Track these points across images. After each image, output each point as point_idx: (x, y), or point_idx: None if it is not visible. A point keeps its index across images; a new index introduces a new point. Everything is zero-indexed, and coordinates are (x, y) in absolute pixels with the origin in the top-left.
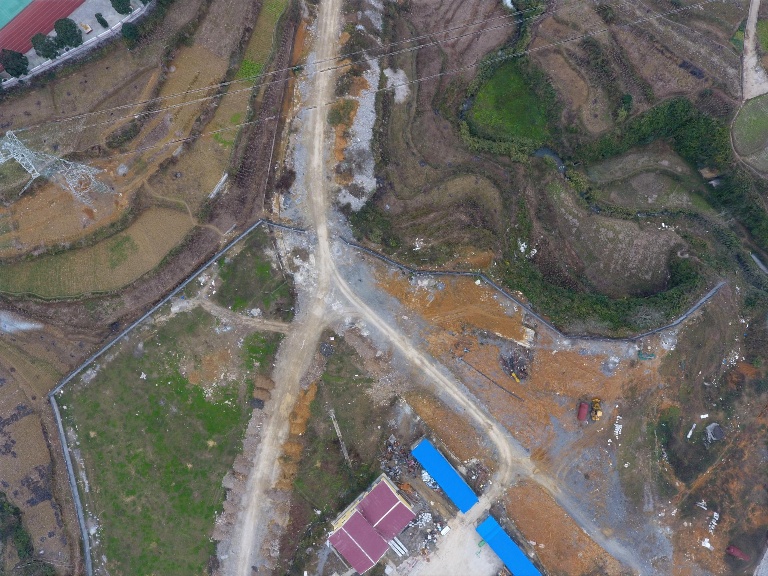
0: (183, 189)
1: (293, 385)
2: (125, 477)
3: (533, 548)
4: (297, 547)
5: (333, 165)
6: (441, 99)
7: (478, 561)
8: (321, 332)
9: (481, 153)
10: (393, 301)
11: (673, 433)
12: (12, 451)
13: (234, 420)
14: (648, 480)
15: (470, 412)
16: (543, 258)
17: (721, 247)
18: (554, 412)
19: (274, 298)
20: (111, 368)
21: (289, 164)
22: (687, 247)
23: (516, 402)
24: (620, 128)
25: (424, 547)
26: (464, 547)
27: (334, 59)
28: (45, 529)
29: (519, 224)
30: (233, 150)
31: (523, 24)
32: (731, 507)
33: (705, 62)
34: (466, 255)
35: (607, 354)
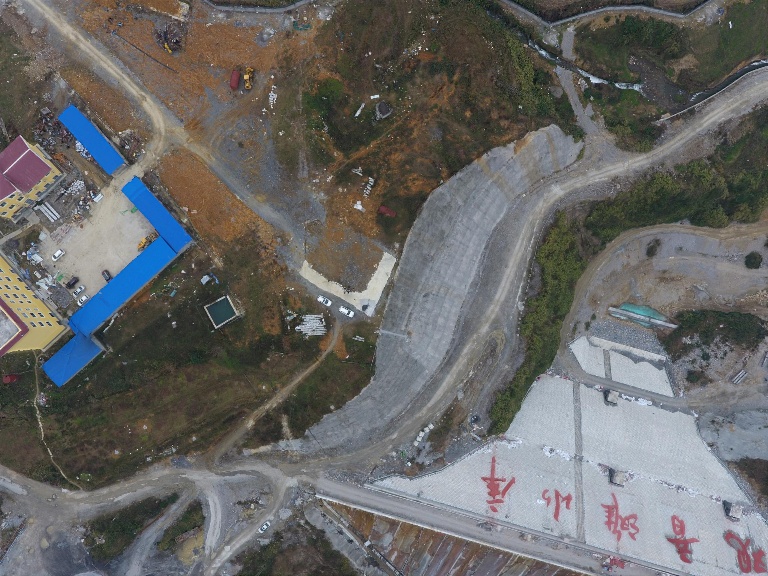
0: None
1: None
2: None
3: (186, 214)
4: None
5: None
6: None
7: (131, 227)
8: None
9: None
10: None
11: (333, 106)
12: None
13: None
14: (303, 148)
15: (124, 85)
16: None
17: None
18: (209, 84)
19: None
20: None
21: None
22: None
23: (170, 74)
24: None
25: (77, 213)
26: (117, 214)
27: None
28: None
29: None
30: None
31: None
32: (388, 173)
33: None
34: None
35: (263, 26)
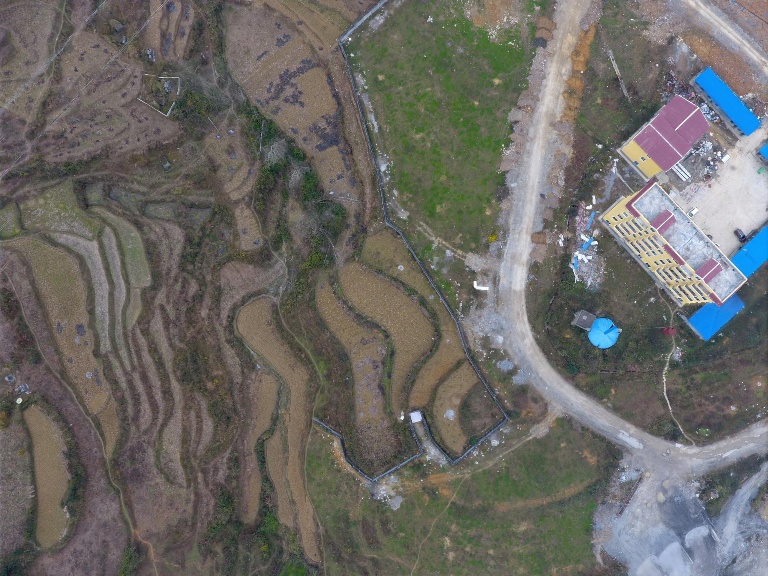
0: None
1: (574, 26)
2: (414, 115)
3: None
4: (581, 178)
5: None
6: None
7: (758, 187)
8: None
9: None
10: None
11: None
12: (299, 101)
13: (518, 59)
14: None
15: (745, 50)
16: None
17: None
18: None
19: None
20: (399, 13)
21: None
22: None
23: None
24: None
25: (706, 173)
26: (744, 174)
27: None
28: (334, 172)
29: None
30: None
31: None
32: None
33: None
34: None
35: None
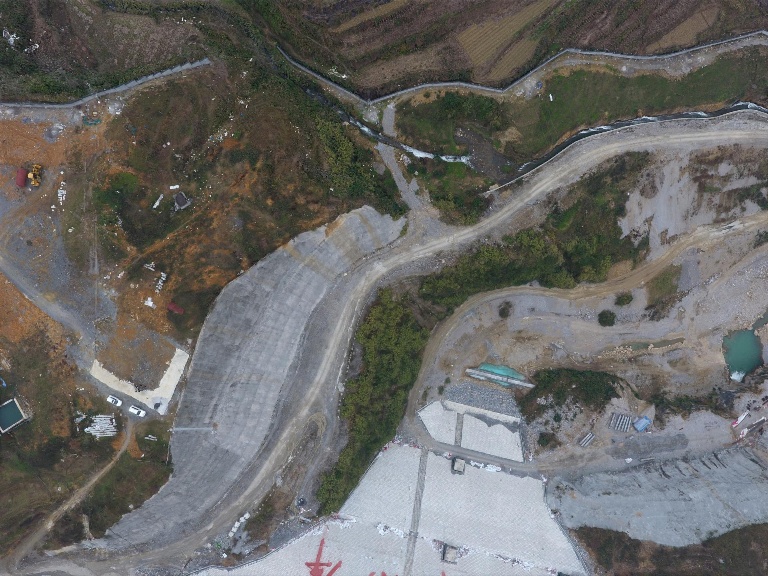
0: None
1: None
2: None
3: None
4: None
5: None
6: None
7: None
8: None
9: None
10: None
11: (127, 199)
12: None
13: None
14: (93, 244)
15: None
16: None
17: (246, 40)
18: None
19: None
20: None
21: None
22: None
23: None
24: None
25: None
26: None
27: None
28: None
29: (2, 13)
30: None
31: None
32: (181, 267)
33: None
34: None
35: (51, 121)
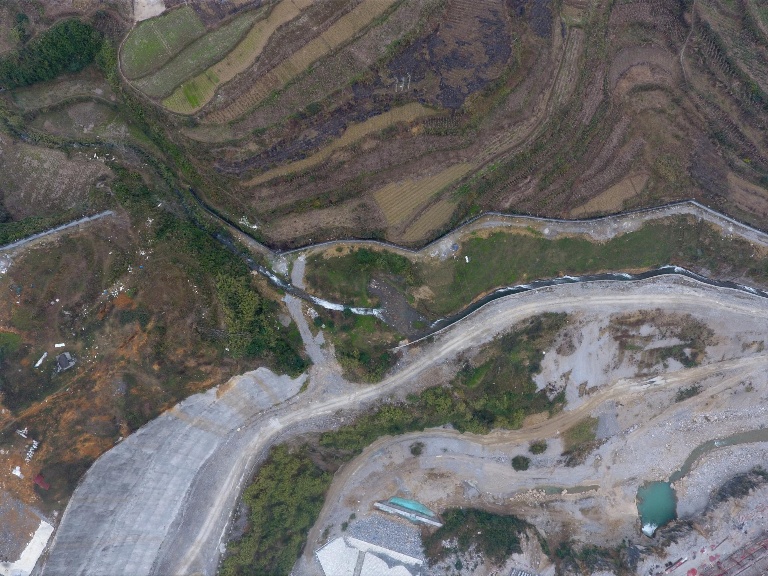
0: None
1: None
2: None
3: None
4: None
5: None
6: None
7: None
8: None
9: None
10: None
11: (6, 359)
12: None
13: None
14: None
15: None
16: None
17: (159, 181)
18: None
19: None
20: None
21: None
22: (112, 178)
23: None
24: (18, 49)
25: None
26: None
27: None
28: None
29: None
30: None
31: None
32: (54, 436)
33: None
34: None
35: None
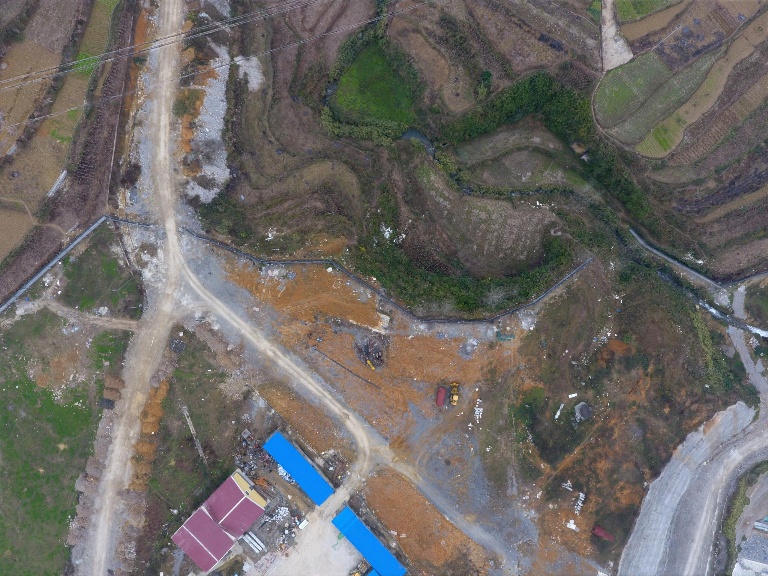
0: (21, 188)
1: (143, 383)
2: None
3: (394, 538)
4: None
5: (180, 157)
6: (299, 85)
7: (338, 554)
8: (171, 328)
9: (341, 138)
10: (243, 293)
11: (537, 414)
12: None
13: (85, 422)
14: (511, 463)
15: (326, 402)
16: (411, 242)
17: (599, 223)
18: (412, 398)
19: (122, 296)
20: None
21: (134, 158)
22: (561, 224)
23: (372, 390)
24: (482, 106)
25: (282, 542)
26: (323, 540)
27: (178, 49)
28: None
29: (381, 209)
30: (71, 146)
31: (380, 4)
32: (597, 487)
33: (563, 34)
34: (319, 242)
35: (465, 337)
